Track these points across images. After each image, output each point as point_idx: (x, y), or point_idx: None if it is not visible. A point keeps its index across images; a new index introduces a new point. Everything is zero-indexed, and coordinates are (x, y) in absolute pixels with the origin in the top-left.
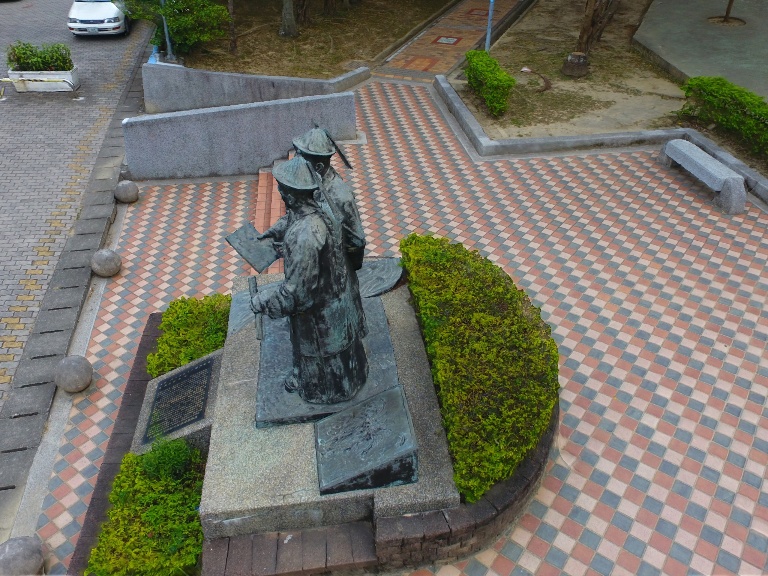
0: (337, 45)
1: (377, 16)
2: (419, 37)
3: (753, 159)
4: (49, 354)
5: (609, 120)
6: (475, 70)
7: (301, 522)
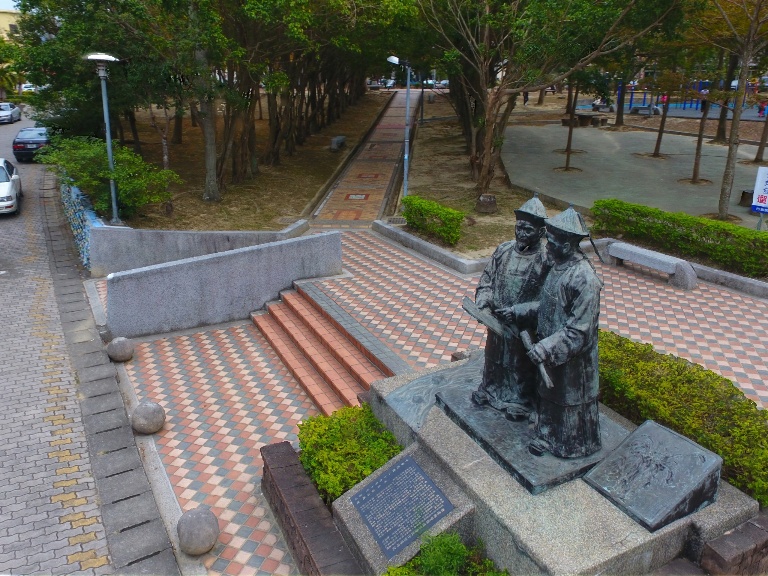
0: (261, 206)
1: (281, 183)
2: (330, 196)
3: (667, 254)
4: (140, 522)
5: None
6: (419, 210)
7: (634, 572)
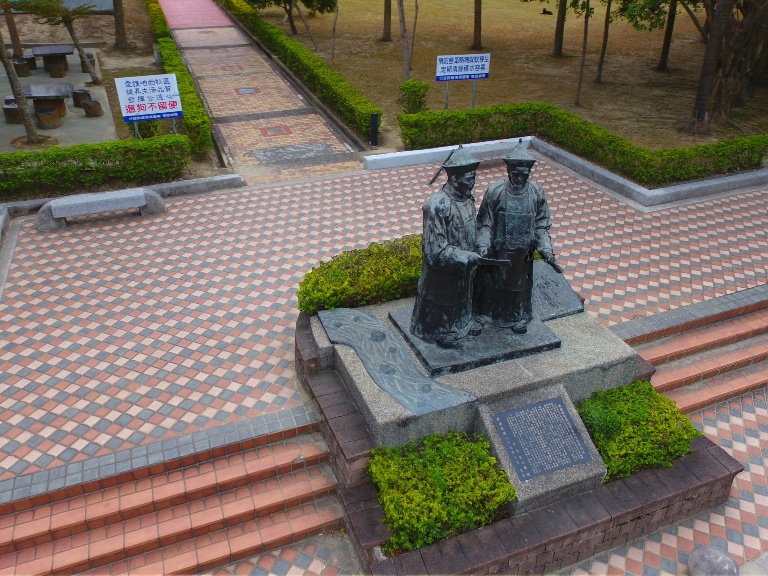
0: None
1: None
2: None
3: (71, 193)
4: None
5: None
6: None
7: None
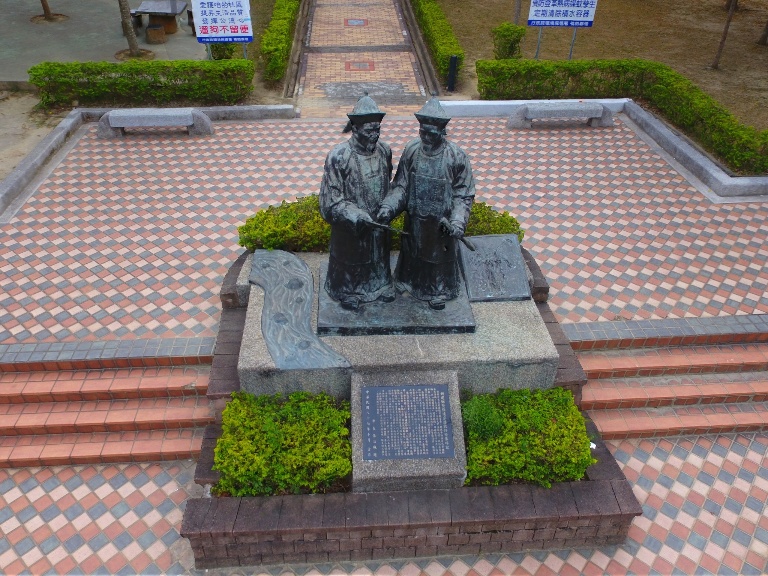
0: None
1: None
2: None
3: (143, 106)
4: None
5: (3, 137)
6: None
7: None
